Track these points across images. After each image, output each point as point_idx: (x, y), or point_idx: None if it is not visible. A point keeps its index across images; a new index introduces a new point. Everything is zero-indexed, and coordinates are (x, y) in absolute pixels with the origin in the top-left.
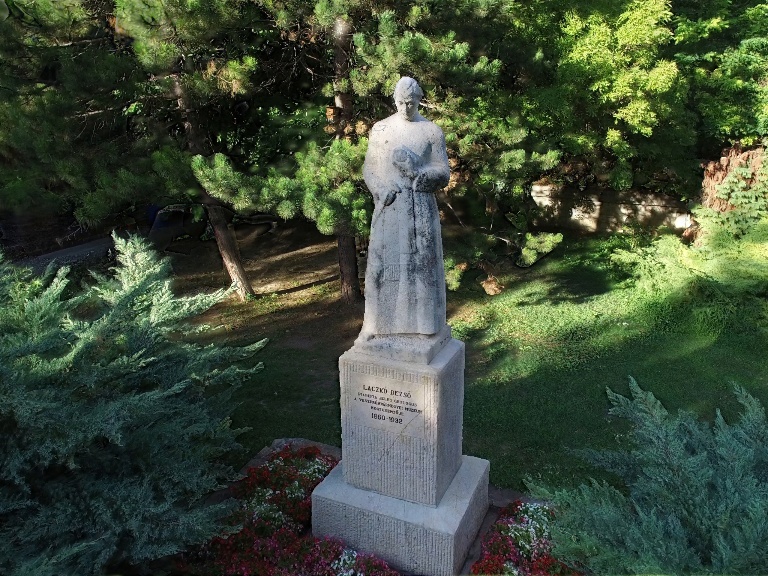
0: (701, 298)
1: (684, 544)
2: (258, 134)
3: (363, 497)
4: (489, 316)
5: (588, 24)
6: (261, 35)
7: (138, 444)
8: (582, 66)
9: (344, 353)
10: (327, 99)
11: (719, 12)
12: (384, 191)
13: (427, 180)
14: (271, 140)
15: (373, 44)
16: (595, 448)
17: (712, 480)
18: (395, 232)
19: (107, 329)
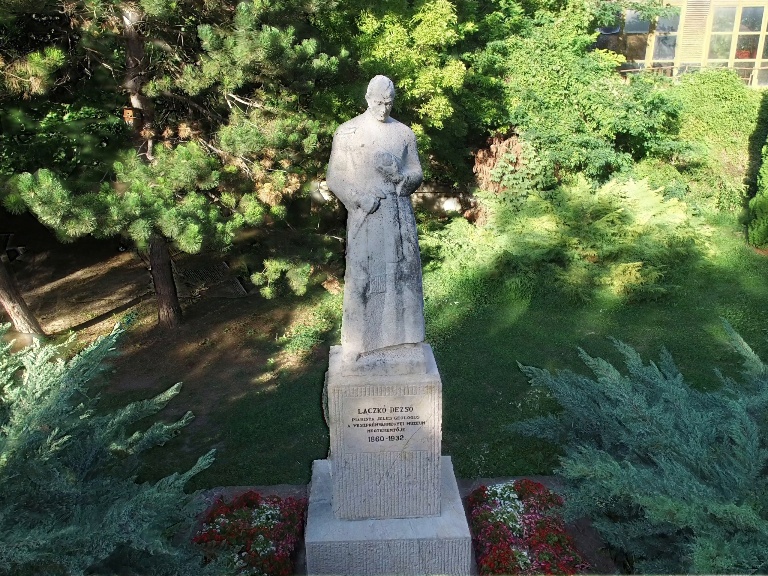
0: (508, 270)
1: (696, 480)
2: (2, 143)
3: (363, 528)
4: (328, 316)
5: (383, 23)
6: (44, 22)
7: (116, 549)
8: (387, 64)
9: (330, 380)
10: (123, 99)
11: (470, 17)
12: (369, 198)
13: (410, 183)
14: (31, 149)
15: (221, 38)
16: (499, 420)
17: (676, 421)
18: (381, 241)
19: (57, 412)
